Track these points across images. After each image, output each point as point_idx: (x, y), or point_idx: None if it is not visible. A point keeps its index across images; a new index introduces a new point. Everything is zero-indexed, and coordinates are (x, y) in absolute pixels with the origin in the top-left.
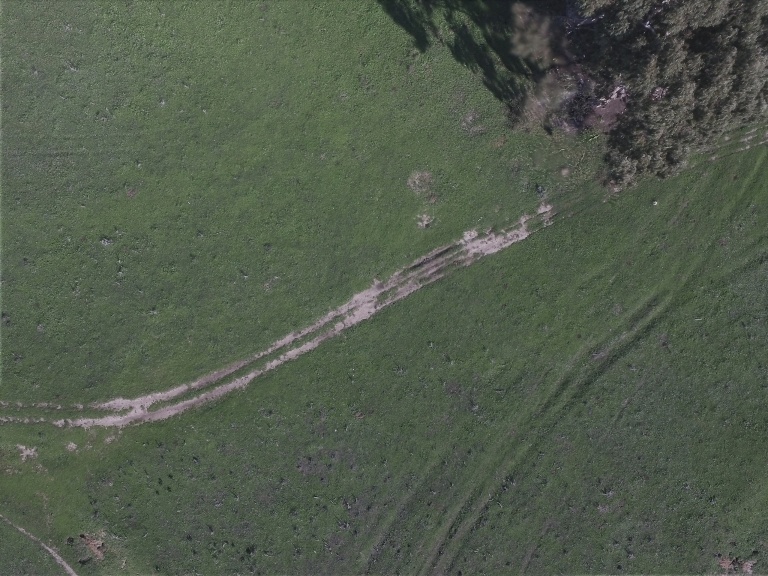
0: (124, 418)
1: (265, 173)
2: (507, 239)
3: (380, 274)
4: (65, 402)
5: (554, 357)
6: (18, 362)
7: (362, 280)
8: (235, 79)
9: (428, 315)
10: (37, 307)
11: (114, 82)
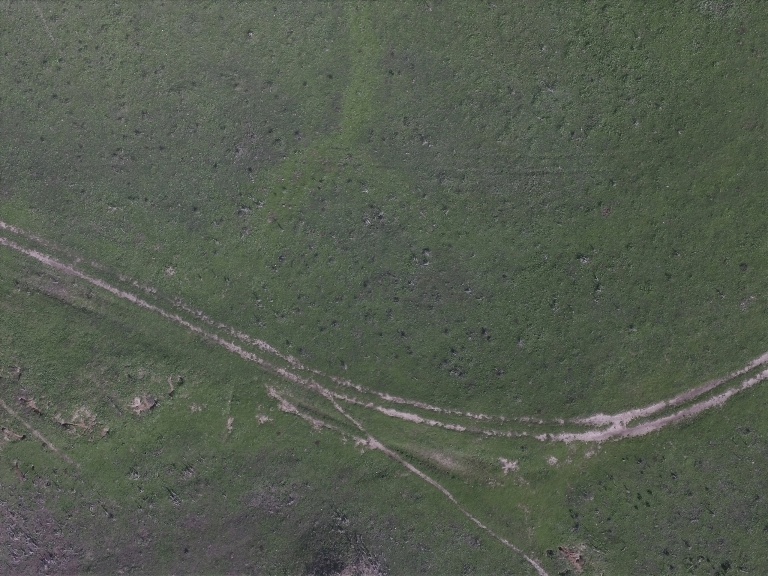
0: (603, 433)
1: (740, 194)
2: None
3: None
4: (547, 417)
5: None
6: (502, 377)
7: None
8: (709, 101)
9: None
10: (516, 323)
11: (588, 103)
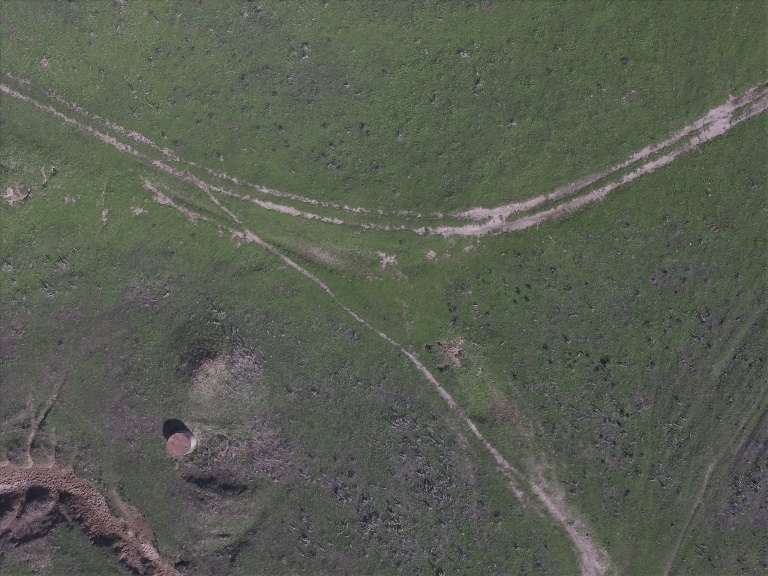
0: (482, 228)
1: None
2: None
3: (736, 90)
4: (425, 210)
5: None
6: (380, 170)
7: (718, 95)
8: None
9: None
10: (396, 118)
11: None
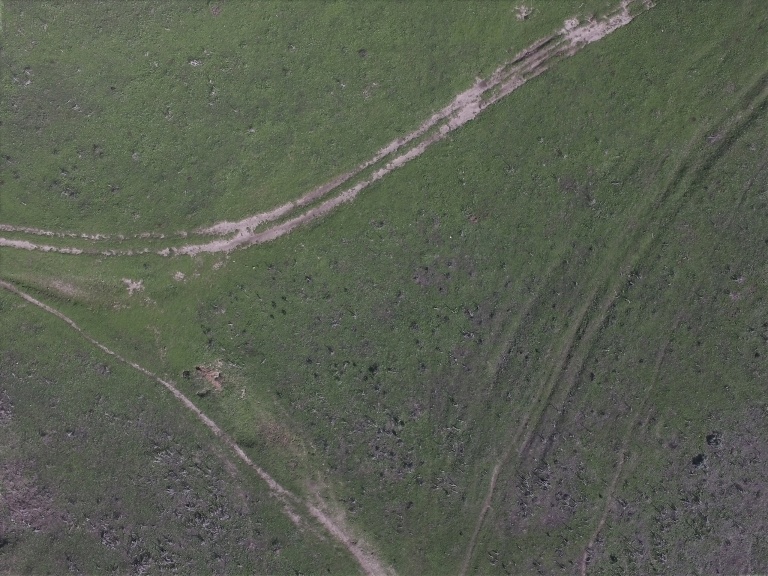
0: (230, 242)
1: None
2: (610, 25)
3: (482, 72)
4: (168, 230)
5: (670, 143)
6: (116, 193)
7: (464, 79)
8: None
9: (535, 110)
10: (130, 136)
11: None
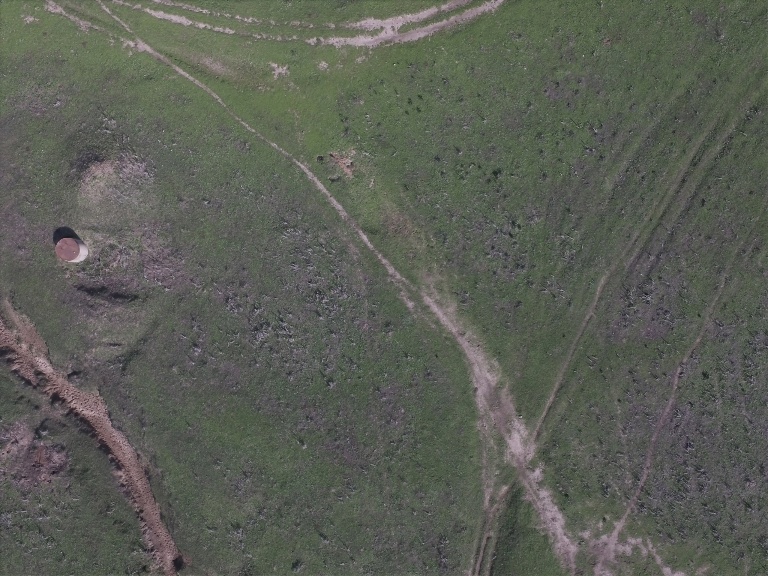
0: (374, 39)
1: None
2: None
3: None
4: (317, 21)
5: None
6: None
7: None
8: None
9: None
10: None
11: None
